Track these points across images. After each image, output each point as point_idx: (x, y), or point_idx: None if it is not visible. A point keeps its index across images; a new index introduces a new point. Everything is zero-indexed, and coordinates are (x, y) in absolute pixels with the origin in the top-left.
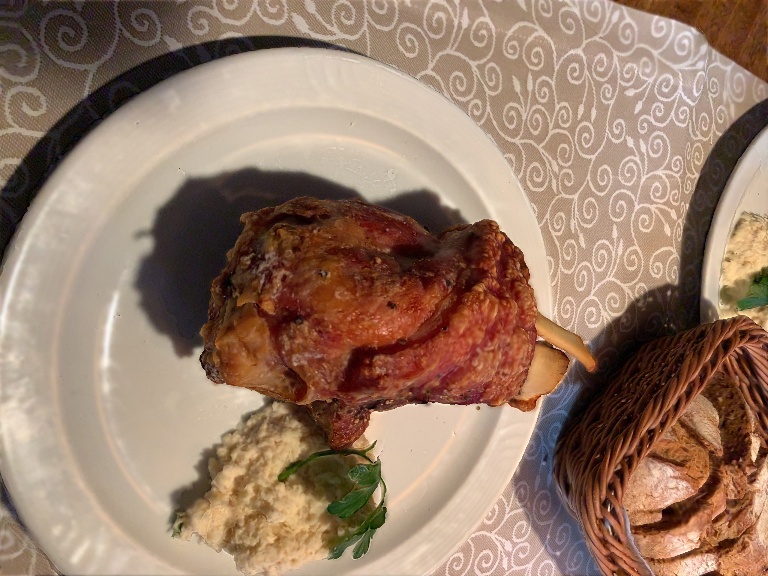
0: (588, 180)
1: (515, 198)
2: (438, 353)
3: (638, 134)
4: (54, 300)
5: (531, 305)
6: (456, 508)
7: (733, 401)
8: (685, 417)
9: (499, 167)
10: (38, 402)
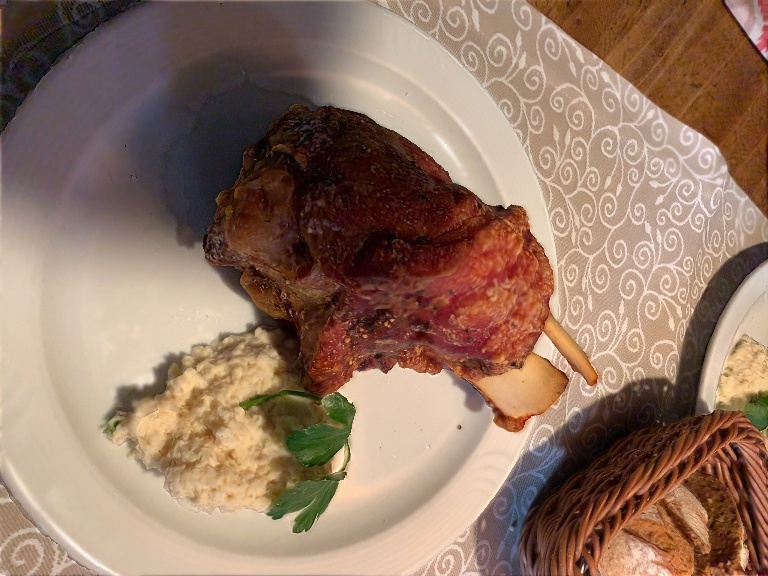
0: (605, 247)
1: (539, 220)
2: (457, 260)
3: (656, 224)
4: (84, 124)
5: (550, 277)
6: (414, 527)
7: (724, 504)
8: (673, 504)
9: (531, 185)
10: (27, 216)
